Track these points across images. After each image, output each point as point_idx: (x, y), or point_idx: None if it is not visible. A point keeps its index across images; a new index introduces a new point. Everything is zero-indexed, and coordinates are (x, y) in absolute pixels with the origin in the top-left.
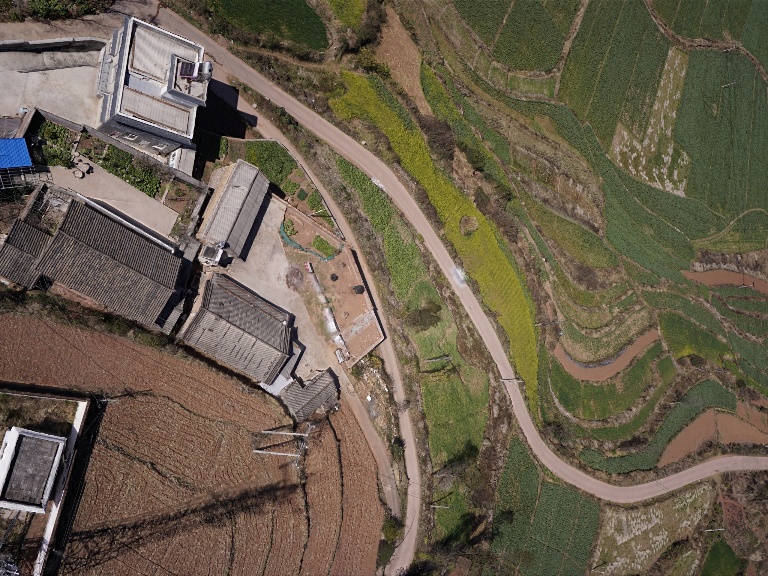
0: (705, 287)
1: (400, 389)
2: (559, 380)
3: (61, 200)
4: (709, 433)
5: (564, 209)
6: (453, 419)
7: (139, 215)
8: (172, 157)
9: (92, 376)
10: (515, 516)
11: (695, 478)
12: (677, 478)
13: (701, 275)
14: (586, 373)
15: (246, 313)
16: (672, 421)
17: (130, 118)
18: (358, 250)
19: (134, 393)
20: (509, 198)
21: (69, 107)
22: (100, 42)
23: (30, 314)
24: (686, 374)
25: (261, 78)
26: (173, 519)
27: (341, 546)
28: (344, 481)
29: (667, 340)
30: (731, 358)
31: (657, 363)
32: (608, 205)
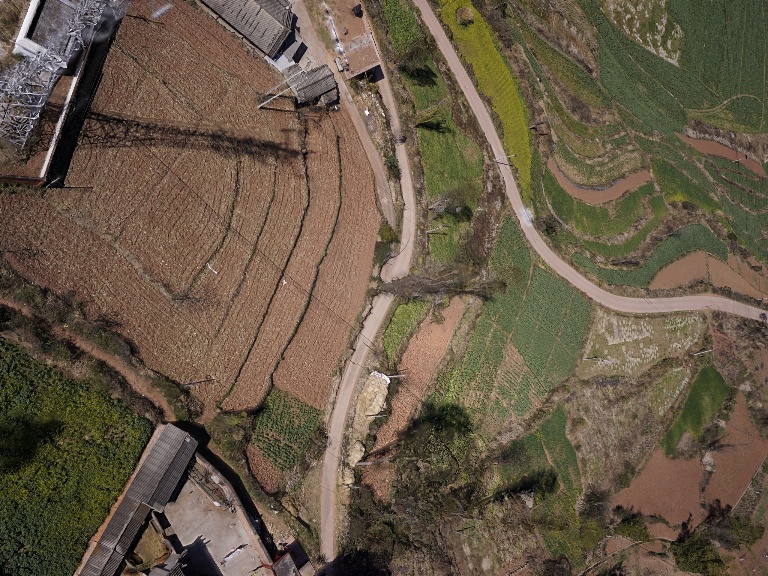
0: (698, 152)
1: (397, 125)
2: (552, 189)
3: None
4: (700, 273)
5: (558, 44)
6: (448, 173)
7: None
8: None
9: None
10: (508, 288)
11: (686, 307)
12: (668, 302)
13: (694, 142)
14: (579, 193)
15: None
16: (663, 251)
17: None
18: None
19: (147, 20)
20: (504, 15)
21: None
22: None
23: None
24: (678, 216)
25: None
26: (183, 134)
27: (339, 230)
28: (343, 173)
29: (659, 184)
30: (723, 214)
31: (649, 199)
32: (602, 53)
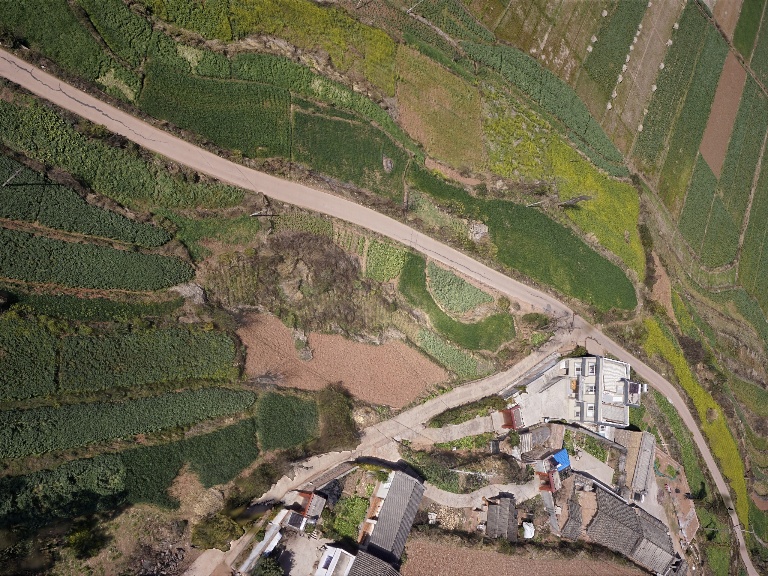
0: None
1: None
2: (753, 514)
3: (584, 484)
4: None
5: (746, 374)
6: (718, 566)
7: (599, 476)
8: (601, 428)
9: None
10: None
11: None
12: None
13: None
14: (766, 504)
15: (654, 532)
16: None
17: None
18: None
19: None
20: None
21: (558, 408)
22: None
23: (579, 557)
24: None
25: (617, 346)
26: None
27: None
28: None
29: None
30: None
31: None
32: None
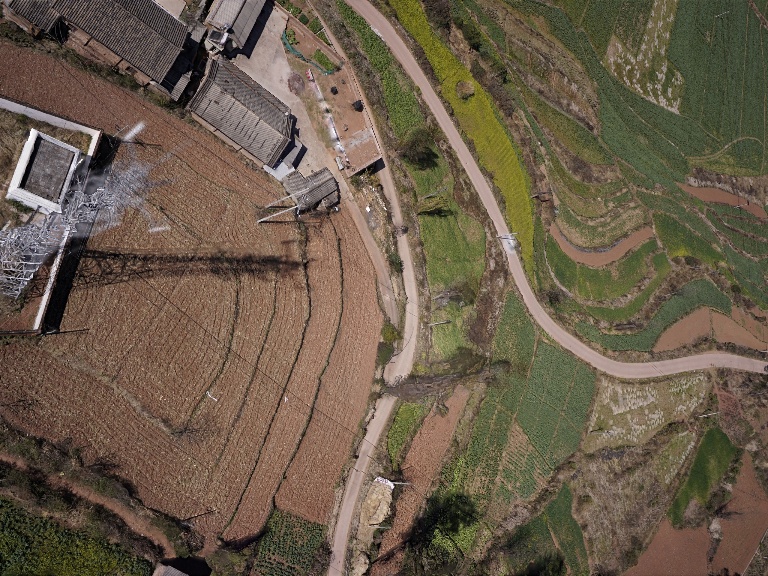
0: (700, 201)
1: (398, 215)
2: (555, 256)
3: None
4: (704, 329)
5: (559, 103)
6: (450, 257)
7: None
8: None
9: (105, 121)
10: (512, 367)
11: (690, 367)
12: (672, 364)
13: (696, 190)
14: (582, 256)
15: (250, 96)
16: (667, 311)
17: None
18: (357, 84)
19: (144, 144)
20: (505, 80)
21: None
22: None
23: (47, 53)
24: (681, 272)
25: None
26: (181, 261)
27: (341, 336)
28: (344, 276)
29: (662, 239)
30: (726, 266)
31: (652, 257)
32: (603, 108)
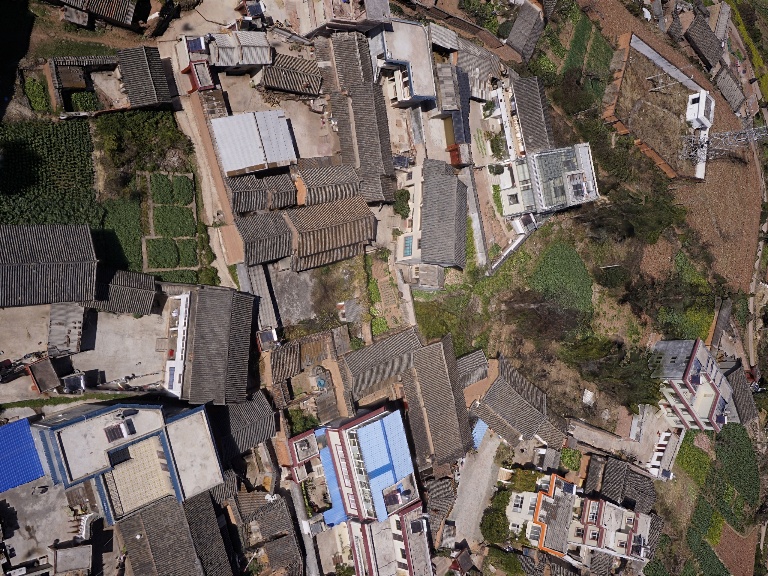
0: None
1: None
2: None
3: None
4: None
5: None
6: None
7: None
8: None
9: None
10: None
11: None
12: None
13: None
14: None
15: None
16: None
17: None
18: None
19: None
20: None
21: None
22: None
23: None
24: None
25: None
26: (723, 156)
27: None
28: None
29: None
30: None
31: None
32: None
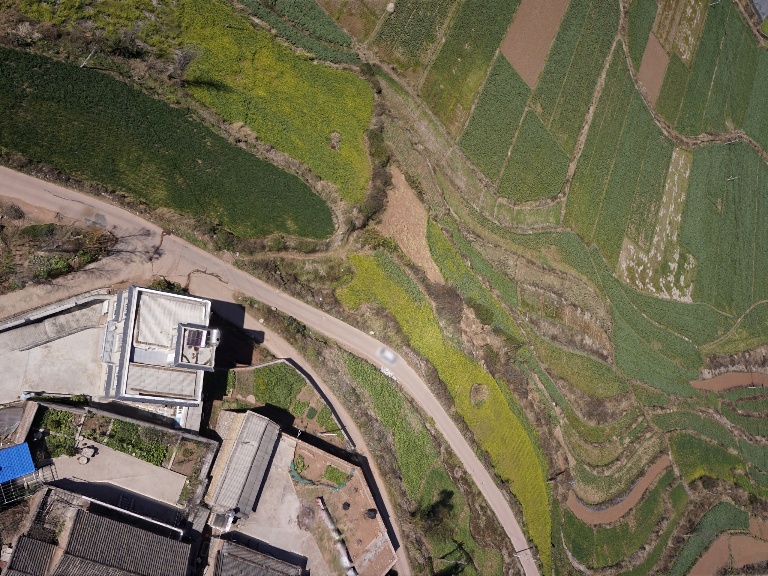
0: (714, 395)
1: None
2: (572, 531)
3: (66, 505)
4: (723, 559)
5: (573, 342)
6: None
7: (146, 488)
8: (179, 409)
9: None
10: None
11: None
12: None
13: (710, 382)
14: (599, 516)
15: None
16: (686, 555)
17: (136, 397)
18: (369, 455)
19: None
20: None
21: (72, 377)
22: (103, 299)
23: None
24: (698, 499)
25: (267, 287)
26: None
27: None
28: None
29: (678, 464)
30: (742, 472)
31: (669, 493)
32: (616, 328)
